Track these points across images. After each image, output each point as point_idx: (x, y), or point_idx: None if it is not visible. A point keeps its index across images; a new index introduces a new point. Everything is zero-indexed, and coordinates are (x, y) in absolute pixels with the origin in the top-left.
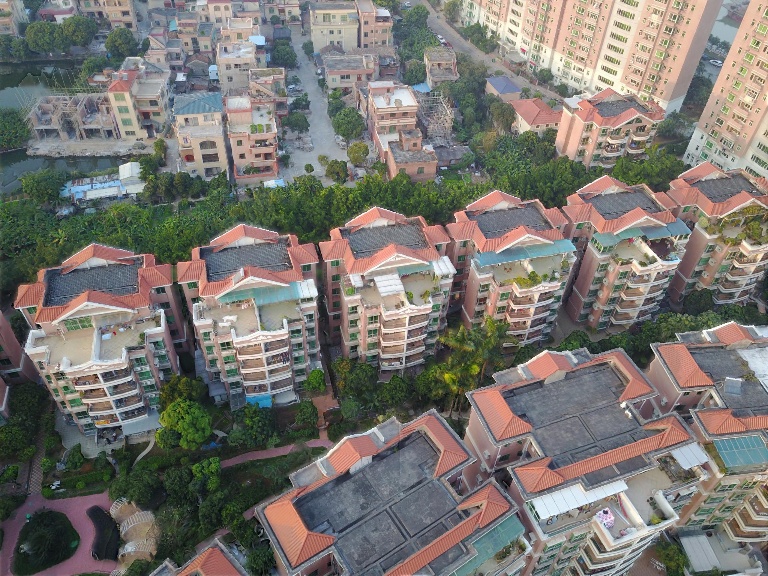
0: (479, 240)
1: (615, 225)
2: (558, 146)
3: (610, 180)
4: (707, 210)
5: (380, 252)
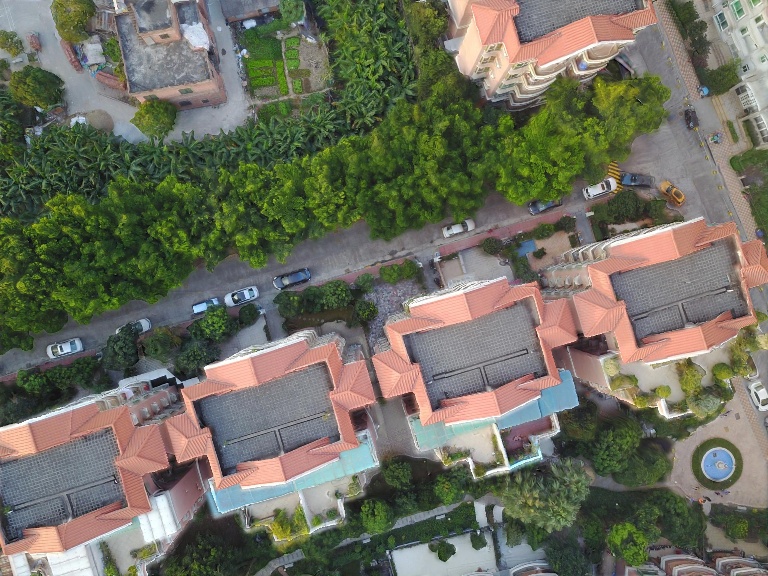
0: (213, 469)
1: (449, 414)
2: (455, 9)
3: (466, 308)
4: (623, 354)
5: (42, 531)
